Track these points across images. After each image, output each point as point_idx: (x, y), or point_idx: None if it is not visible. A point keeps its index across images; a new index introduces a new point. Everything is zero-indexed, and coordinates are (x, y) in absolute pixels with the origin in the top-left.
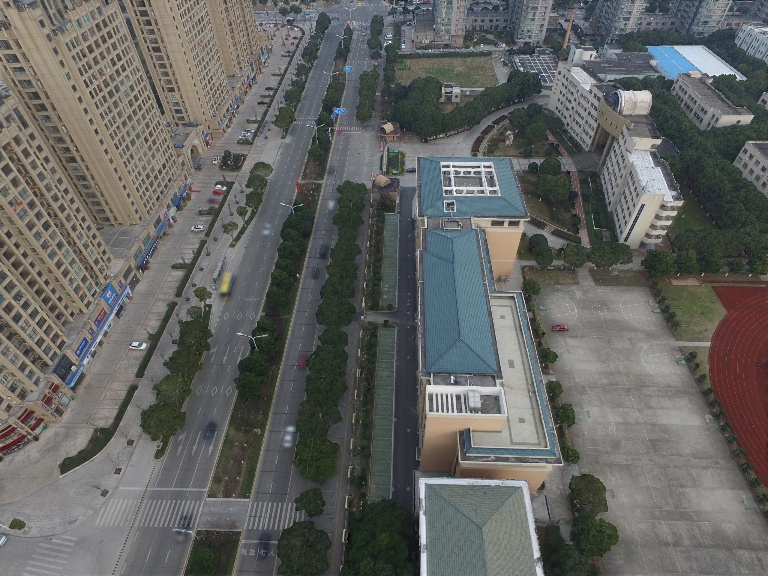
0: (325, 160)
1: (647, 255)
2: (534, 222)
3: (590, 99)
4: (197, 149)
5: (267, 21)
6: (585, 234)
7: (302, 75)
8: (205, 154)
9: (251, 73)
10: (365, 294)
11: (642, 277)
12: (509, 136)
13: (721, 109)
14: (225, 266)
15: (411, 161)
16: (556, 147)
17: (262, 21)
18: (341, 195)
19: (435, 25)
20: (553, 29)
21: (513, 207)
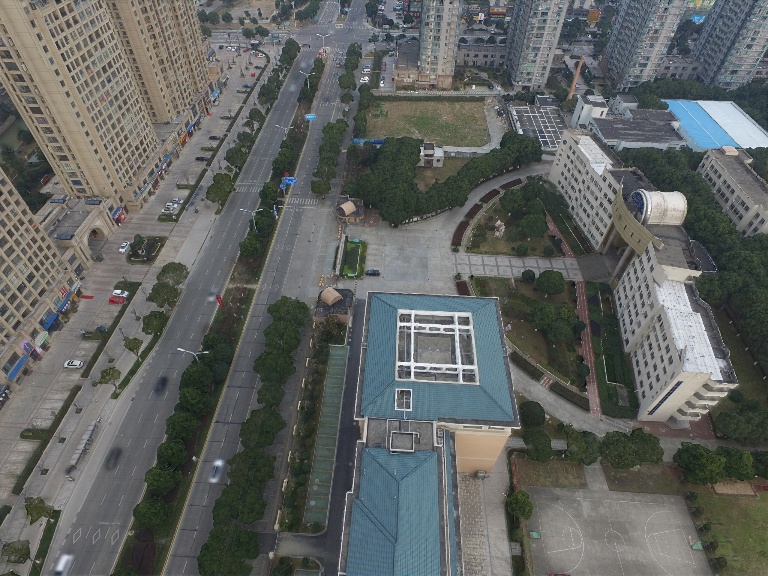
0: (265, 251)
1: (683, 451)
2: (527, 369)
3: (603, 187)
4: (101, 231)
5: (228, 44)
6: (594, 392)
7: (253, 124)
8: (113, 235)
9: (192, 118)
10: (283, 500)
11: (674, 476)
12: (499, 228)
13: (767, 207)
14: (97, 435)
15: (374, 257)
16: (558, 243)
17: (223, 43)
18: (269, 325)
19: (419, 62)
20: (557, 69)
21: (496, 405)
